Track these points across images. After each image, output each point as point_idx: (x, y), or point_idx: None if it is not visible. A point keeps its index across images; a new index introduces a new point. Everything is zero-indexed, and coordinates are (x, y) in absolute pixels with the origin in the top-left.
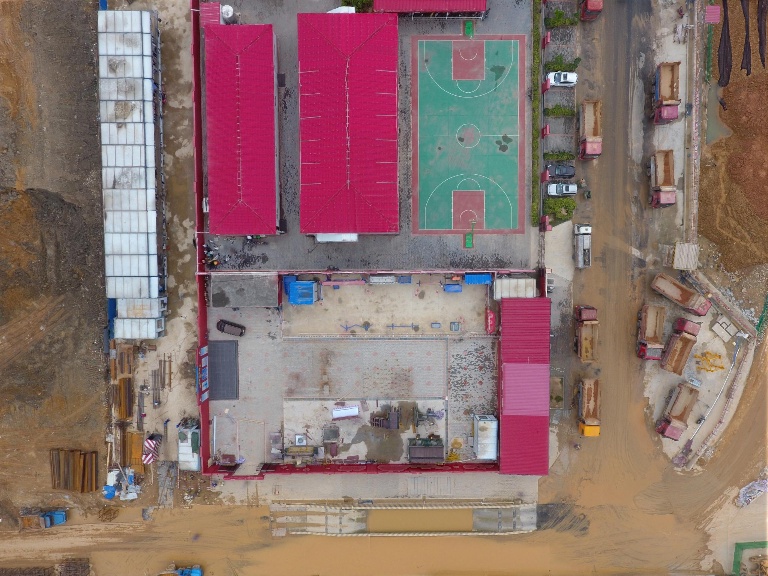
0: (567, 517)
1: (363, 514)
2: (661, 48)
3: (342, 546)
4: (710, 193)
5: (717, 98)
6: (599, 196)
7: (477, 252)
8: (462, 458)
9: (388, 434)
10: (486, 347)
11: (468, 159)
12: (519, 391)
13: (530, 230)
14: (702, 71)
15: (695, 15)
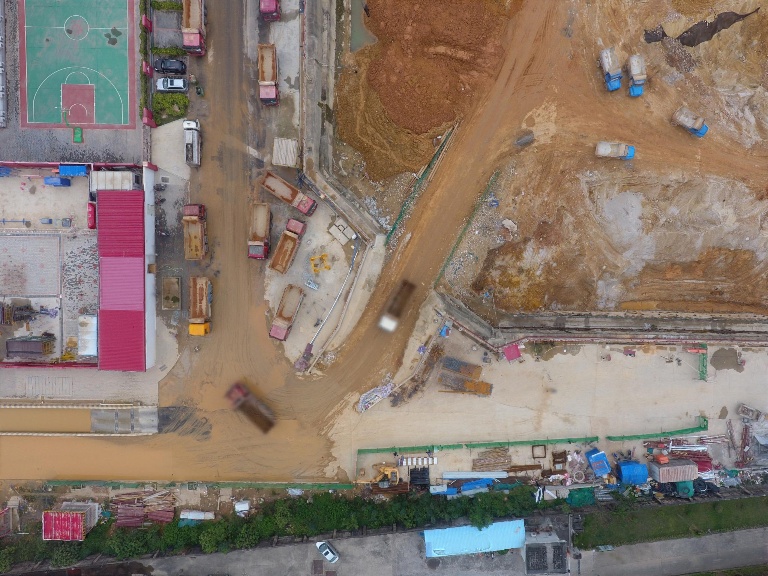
0: (189, 421)
1: None
2: None
3: None
4: (350, 100)
5: (362, 5)
6: (215, 94)
7: (88, 147)
8: (78, 358)
9: (1, 331)
10: None
11: (77, 52)
12: (115, 285)
13: None
14: None
15: None
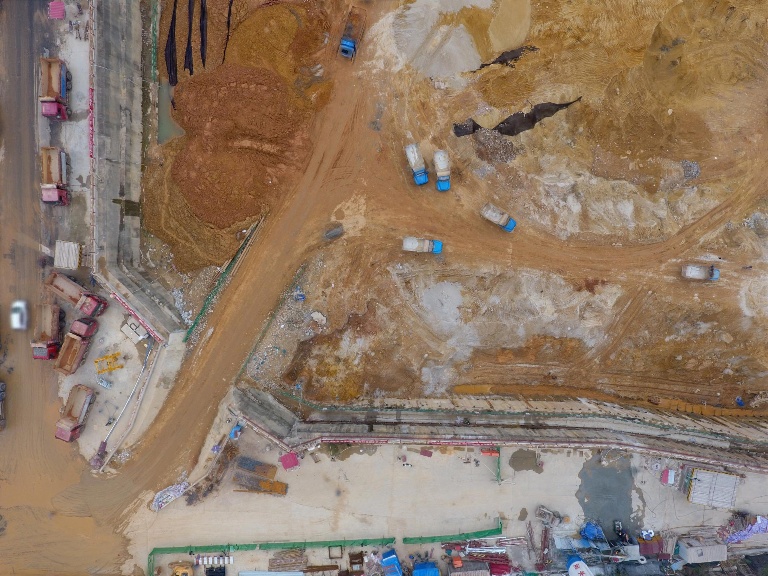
0: None
1: None
2: (65, 44)
3: None
4: (155, 193)
5: (169, 97)
6: (6, 192)
7: None
8: None
9: None
10: None
11: None
12: None
13: None
14: (103, 68)
15: (93, 12)
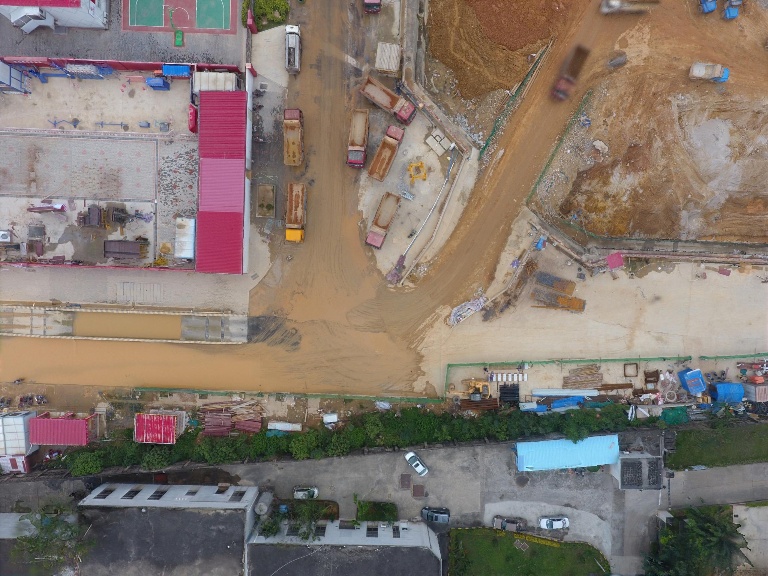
0: (278, 331)
1: (69, 317)
2: None
3: (46, 348)
4: (445, 16)
5: None
6: (315, 1)
7: (188, 51)
8: (170, 263)
9: (95, 235)
10: (197, 150)
11: None
12: (215, 187)
13: (242, 31)
14: None
15: None
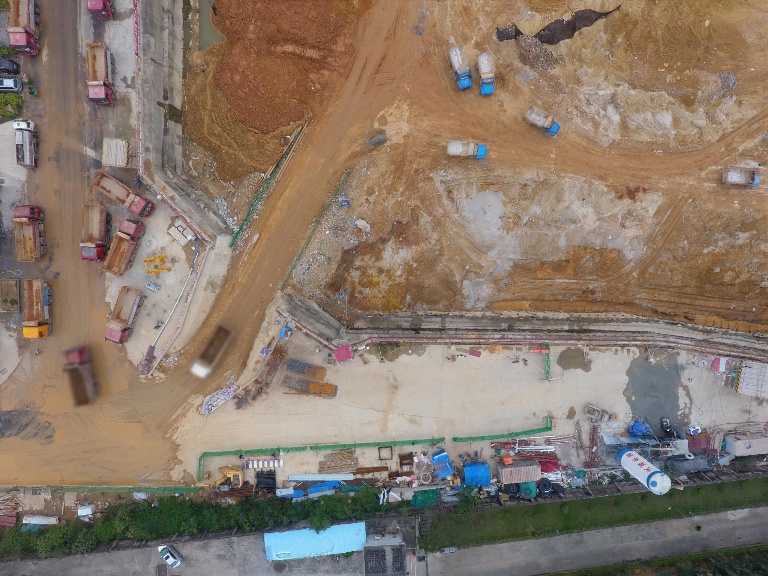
0: (31, 424)
1: None
2: None
3: None
4: (197, 99)
5: (210, 3)
6: (50, 94)
7: None
8: None
9: None
10: None
11: None
12: None
13: None
14: None
15: None
